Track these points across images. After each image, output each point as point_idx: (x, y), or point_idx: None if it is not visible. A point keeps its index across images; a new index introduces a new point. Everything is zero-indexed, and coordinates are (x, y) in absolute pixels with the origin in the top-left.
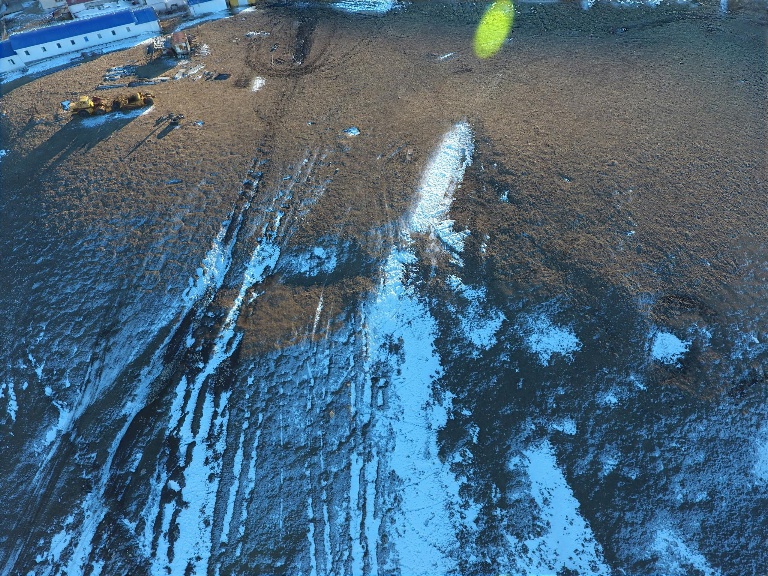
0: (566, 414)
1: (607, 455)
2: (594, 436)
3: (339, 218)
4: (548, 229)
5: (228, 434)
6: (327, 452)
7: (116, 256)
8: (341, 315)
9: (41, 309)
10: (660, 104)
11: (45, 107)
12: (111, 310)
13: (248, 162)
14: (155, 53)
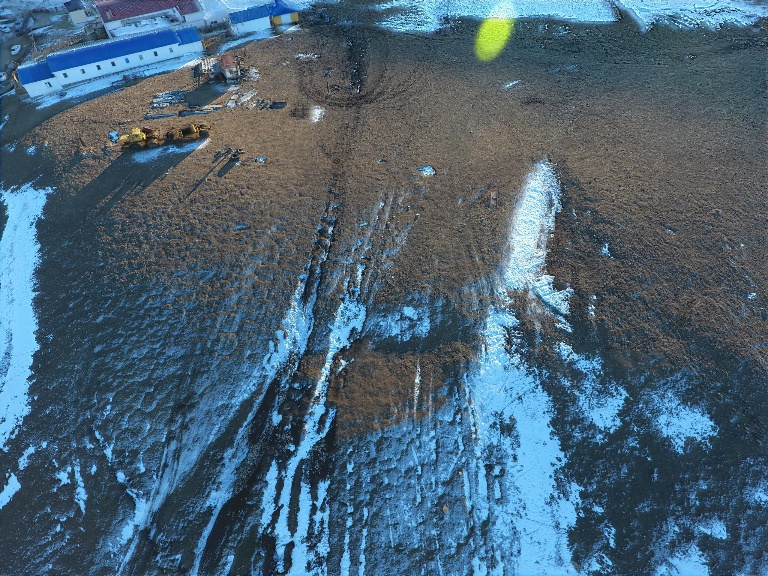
0: (712, 514)
1: (766, 565)
2: (748, 541)
3: (427, 272)
4: (660, 289)
5: (331, 533)
6: (445, 556)
7: (185, 315)
8: (443, 389)
9: (106, 377)
10: (754, 144)
11: (91, 138)
12: (185, 380)
13: (320, 205)
14: (202, 77)
